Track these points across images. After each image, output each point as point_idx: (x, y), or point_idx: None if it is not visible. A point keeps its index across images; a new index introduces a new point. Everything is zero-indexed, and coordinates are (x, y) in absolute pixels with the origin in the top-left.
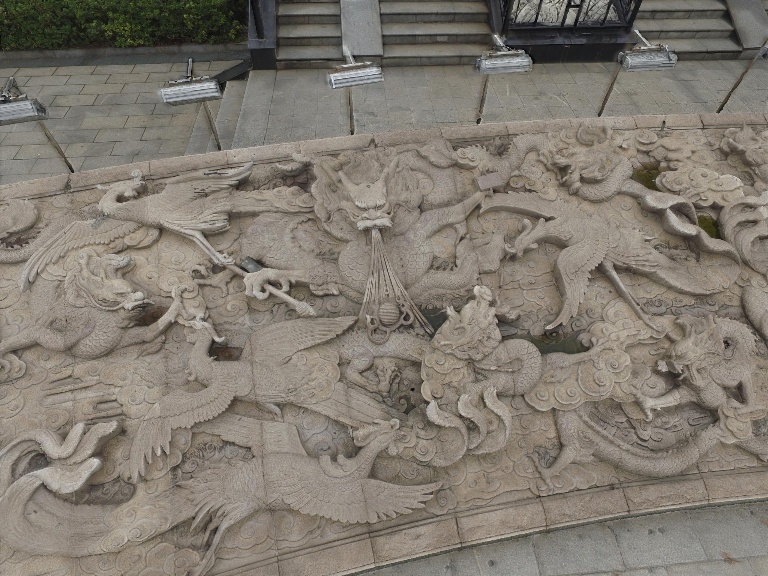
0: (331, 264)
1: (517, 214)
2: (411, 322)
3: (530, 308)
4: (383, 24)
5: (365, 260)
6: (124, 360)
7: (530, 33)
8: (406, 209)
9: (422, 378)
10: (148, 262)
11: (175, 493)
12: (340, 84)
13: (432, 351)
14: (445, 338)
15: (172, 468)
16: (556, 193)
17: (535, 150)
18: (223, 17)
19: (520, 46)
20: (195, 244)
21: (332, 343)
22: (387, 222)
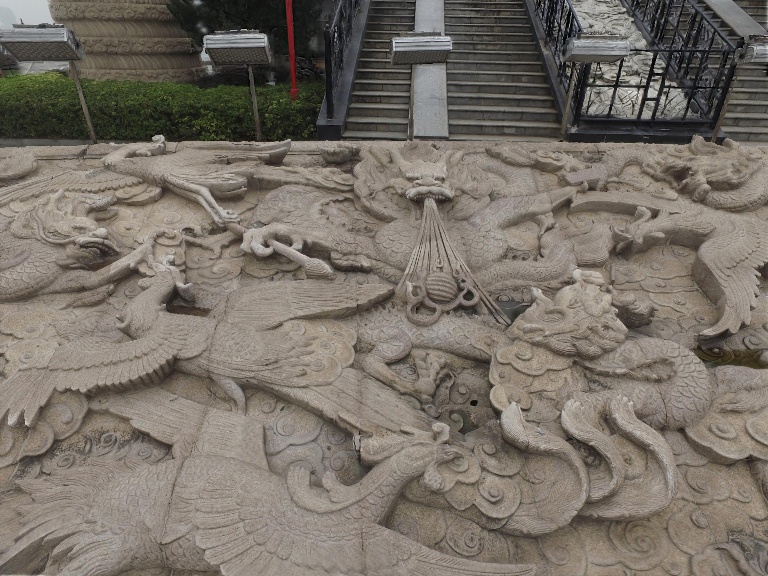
0: (365, 237)
1: (623, 215)
2: (475, 302)
3: (665, 314)
4: (450, 119)
5: (412, 233)
6: (45, 307)
7: (603, 125)
8: (471, 196)
9: (491, 381)
10: (134, 217)
11: (5, 500)
12: (401, 48)
13: (509, 343)
14: (531, 323)
15: (27, 459)
16: (676, 194)
17: (636, 164)
18: (300, 118)
19: (594, 135)
20: (199, 208)
21: (349, 320)
22: (446, 190)
